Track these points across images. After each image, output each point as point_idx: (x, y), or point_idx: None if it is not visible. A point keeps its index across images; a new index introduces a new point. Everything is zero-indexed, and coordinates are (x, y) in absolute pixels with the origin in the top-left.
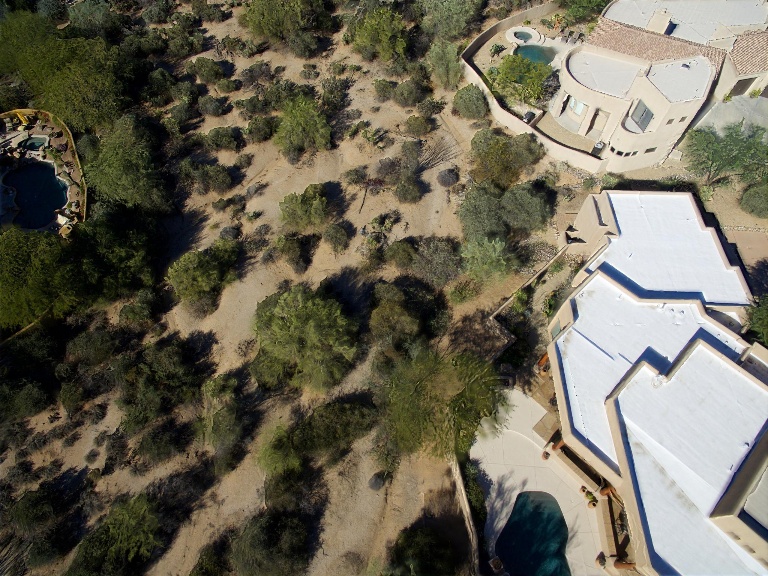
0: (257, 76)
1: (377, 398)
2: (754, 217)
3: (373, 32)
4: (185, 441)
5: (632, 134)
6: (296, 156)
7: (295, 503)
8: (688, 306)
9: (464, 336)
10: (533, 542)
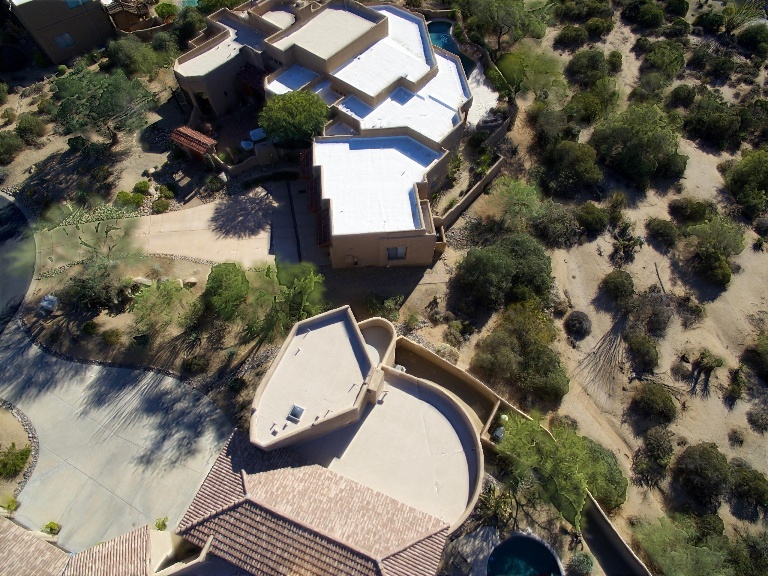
0: None
1: None
2: None
3: None
4: None
5: (382, 318)
6: None
7: None
8: None
9: (515, 168)
10: None
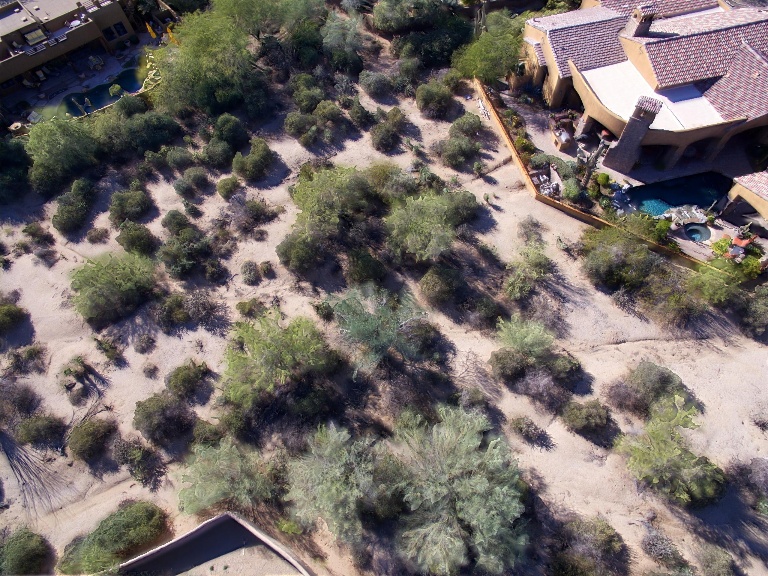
0: None
1: None
2: None
3: None
4: None
5: None
6: None
7: None
8: None
9: None
10: None
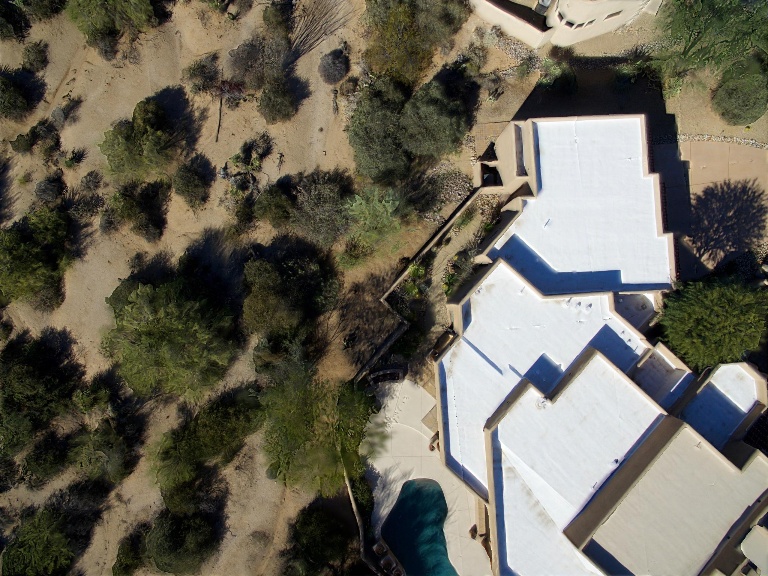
0: None
1: (261, 400)
2: (722, 123)
3: None
4: (73, 453)
5: (587, 2)
6: (108, 46)
7: (194, 508)
8: (598, 297)
9: (356, 310)
10: (418, 513)
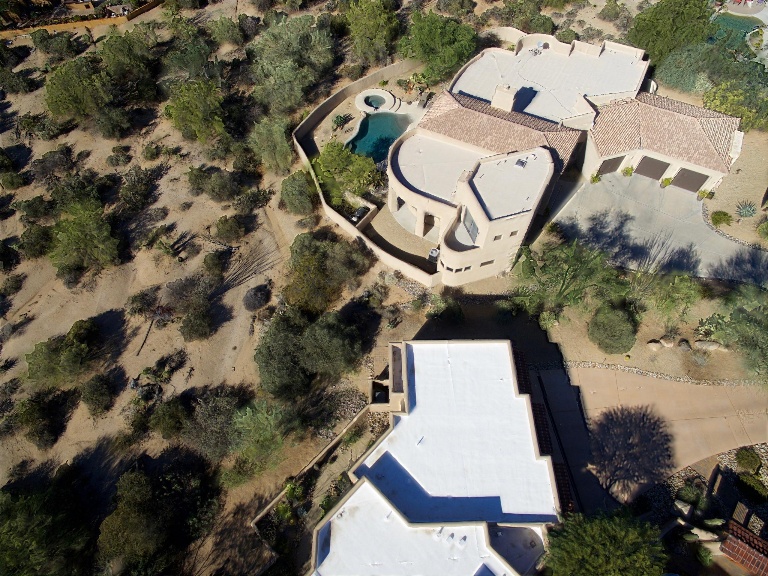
0: (52, 166)
1: None
2: (601, 351)
3: (184, 111)
4: None
5: (454, 253)
6: (73, 278)
7: None
8: (473, 528)
9: (231, 537)
10: None
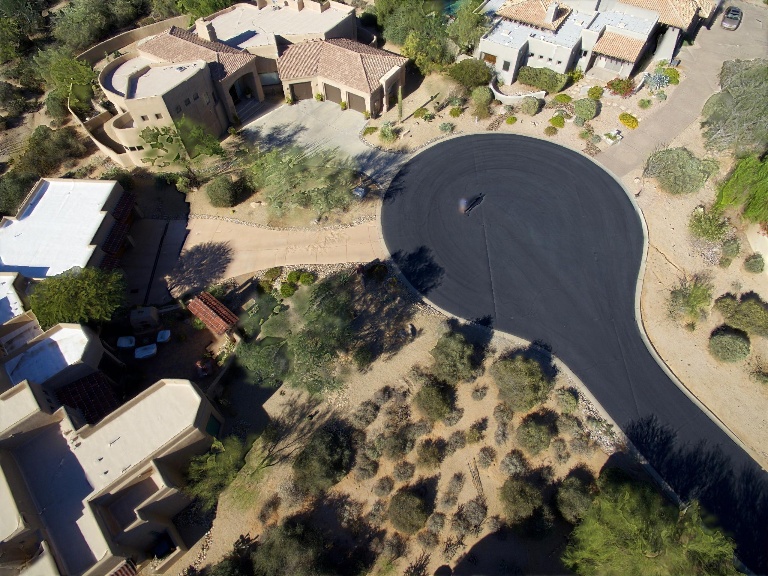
0: None
1: None
2: None
3: None
4: None
5: (116, 129)
6: None
7: None
8: (13, 278)
9: None
10: None
